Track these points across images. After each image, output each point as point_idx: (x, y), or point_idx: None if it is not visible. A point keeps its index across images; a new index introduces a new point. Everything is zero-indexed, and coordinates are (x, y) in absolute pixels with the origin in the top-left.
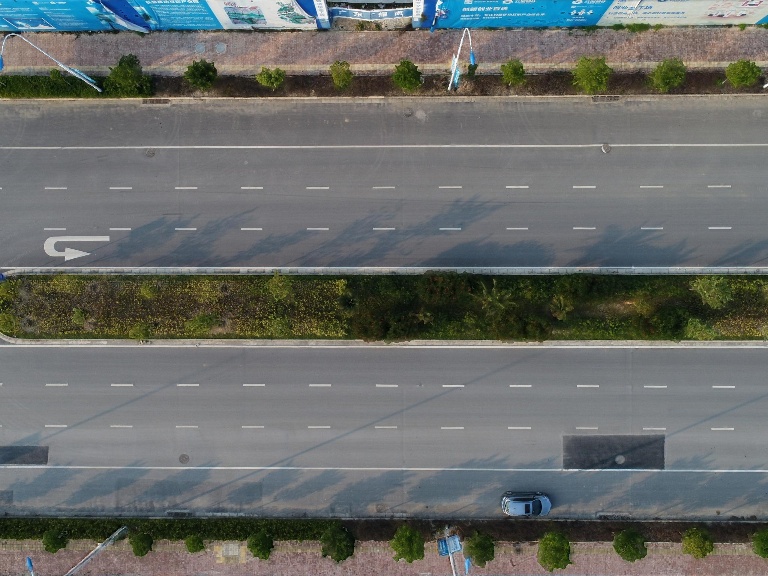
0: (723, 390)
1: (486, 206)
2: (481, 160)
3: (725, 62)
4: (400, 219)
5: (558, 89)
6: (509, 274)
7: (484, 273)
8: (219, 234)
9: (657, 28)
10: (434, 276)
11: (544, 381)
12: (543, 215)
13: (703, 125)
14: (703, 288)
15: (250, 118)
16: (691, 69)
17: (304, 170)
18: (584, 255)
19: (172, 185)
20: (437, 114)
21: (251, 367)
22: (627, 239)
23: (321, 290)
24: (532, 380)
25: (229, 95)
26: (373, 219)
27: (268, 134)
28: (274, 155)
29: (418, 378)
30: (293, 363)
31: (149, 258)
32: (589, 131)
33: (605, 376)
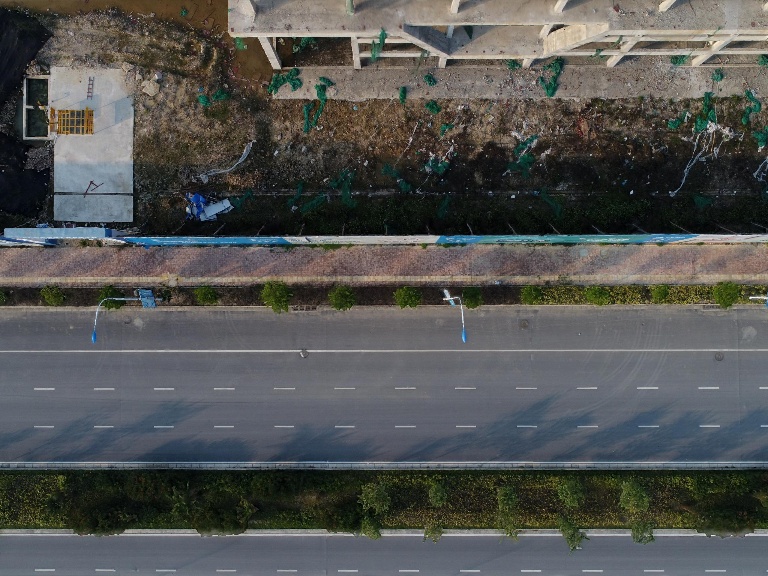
0: (409, 574)
1: (196, 406)
2: (192, 364)
3: (409, 277)
4: (118, 418)
5: (261, 300)
6: (215, 469)
7: (193, 468)
8: None
9: (348, 246)
10: (140, 476)
11: (248, 566)
12: (247, 414)
13: (391, 333)
14: (364, 497)
15: None
16: (379, 283)
17: (32, 373)
18: (284, 451)
19: None
20: (153, 322)
21: None
22: (322, 436)
23: (44, 484)
24: (237, 565)
25: None
26: (94, 418)
27: (0, 340)
28: (5, 359)
29: (134, 563)
30: (20, 550)
31: None
32: (289, 338)
33: (303, 561)
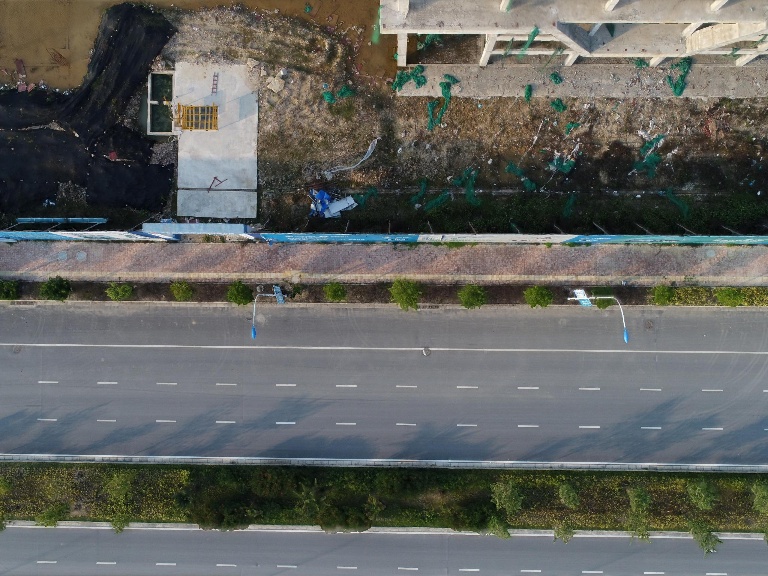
0: (530, 574)
1: (318, 403)
2: (314, 361)
3: (534, 276)
4: (240, 413)
5: (384, 298)
6: (337, 466)
7: (315, 464)
8: (77, 425)
9: (472, 245)
10: (265, 472)
11: (369, 563)
12: (369, 412)
13: (514, 332)
14: (496, 496)
15: (107, 319)
16: (503, 282)
17: (155, 367)
18: (406, 449)
19: (35, 379)
20: (275, 318)
21: (104, 547)
22: (445, 435)
23: (167, 479)
24: (358, 562)
25: (88, 299)
26: (216, 413)
27: (123, 334)
28: (128, 353)
29: (255, 559)
30: (142, 543)
31: (13, 446)
32: (412, 336)
33: (424, 559)
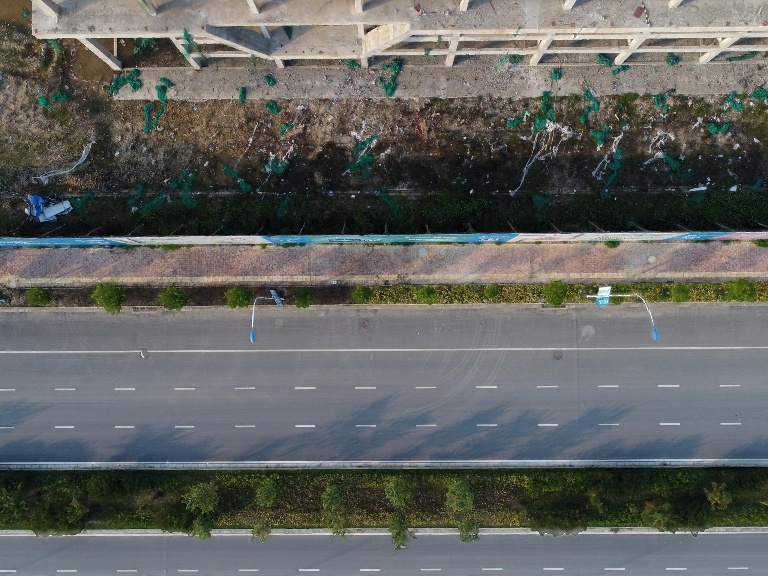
0: (248, 573)
1: (37, 407)
2: (33, 365)
3: (249, 277)
4: None
5: None
6: (55, 469)
7: (33, 469)
8: None
9: (187, 247)
10: None
11: (88, 566)
12: (88, 415)
13: (231, 333)
14: (189, 497)
15: None
16: (219, 283)
17: None
18: (124, 451)
19: None
20: None
21: None
22: (162, 436)
23: None
24: (77, 565)
25: None
26: None
27: None
28: None
29: None
30: None
31: None
32: (130, 338)
33: (142, 561)
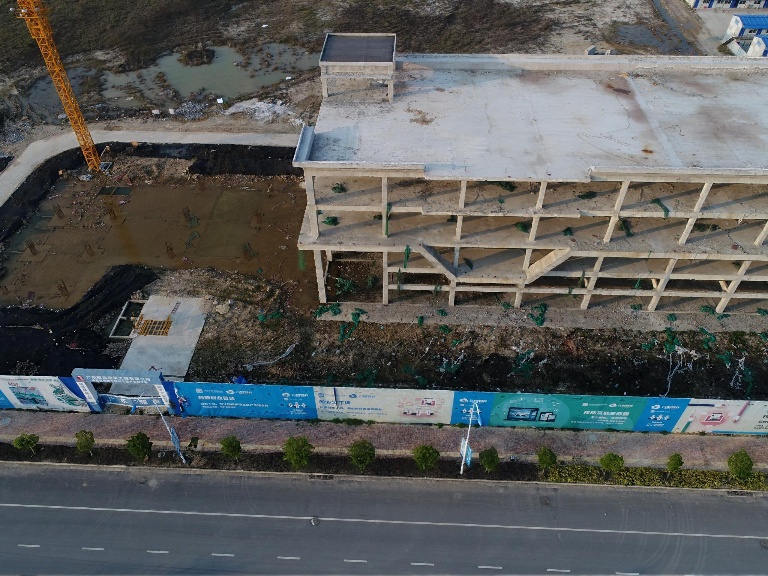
0: None
1: (187, 573)
2: (195, 526)
3: None
4: None
5: (280, 467)
6: None
7: None
8: None
9: (369, 423)
10: None
11: None
12: None
13: (408, 504)
14: None
15: None
16: (397, 456)
17: (24, 528)
18: None
19: None
20: (168, 483)
21: None
22: None
23: None
24: None
25: None
26: None
27: (8, 493)
28: (3, 512)
29: None
30: None
31: None
32: (302, 504)
33: None
